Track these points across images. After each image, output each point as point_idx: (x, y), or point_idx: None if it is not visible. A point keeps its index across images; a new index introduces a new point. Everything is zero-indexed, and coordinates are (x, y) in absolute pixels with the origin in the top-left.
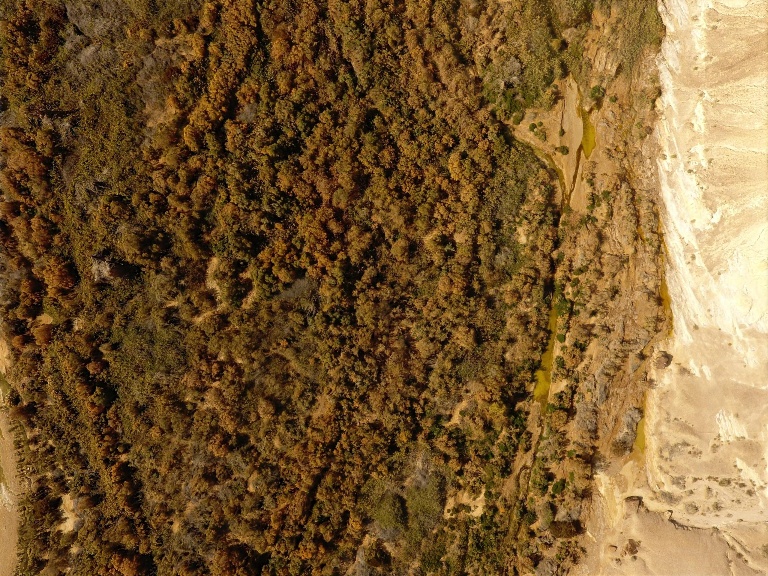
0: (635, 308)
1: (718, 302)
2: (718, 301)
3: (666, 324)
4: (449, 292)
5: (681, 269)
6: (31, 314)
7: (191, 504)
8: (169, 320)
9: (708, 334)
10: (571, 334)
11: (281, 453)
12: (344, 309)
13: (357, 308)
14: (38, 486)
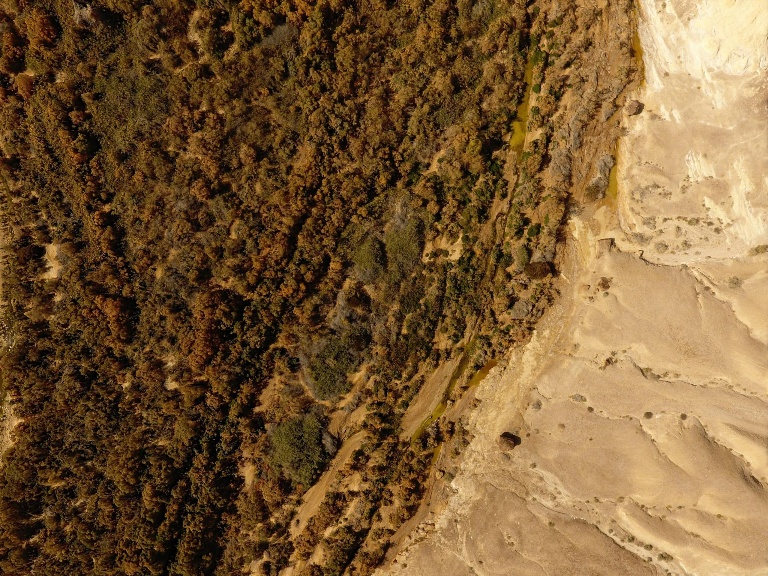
0: (608, 59)
1: (688, 48)
2: (688, 47)
3: (638, 74)
4: (427, 36)
5: (652, 20)
6: (13, 69)
7: (174, 251)
8: (151, 67)
9: (678, 79)
10: (546, 83)
11: (263, 201)
12: (324, 55)
13: (337, 55)
14: (21, 234)
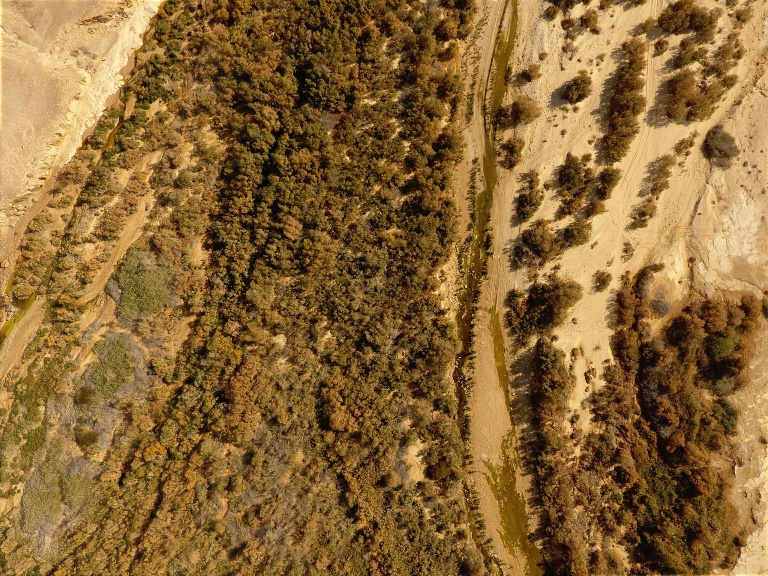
0: None
1: None
2: None
3: None
4: None
5: None
6: None
7: (285, 482)
8: None
9: None
10: None
11: (194, 540)
12: None
13: None
14: None
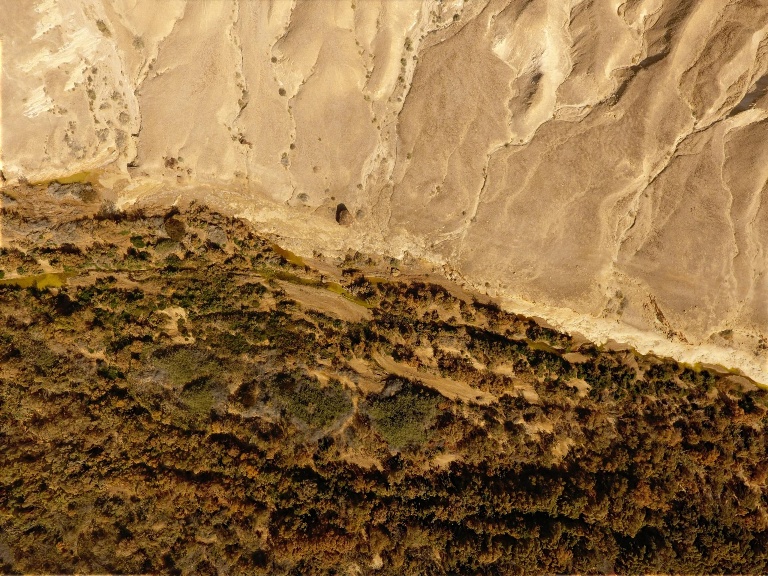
0: None
1: None
2: None
3: None
4: None
5: None
6: None
7: None
8: None
9: None
10: None
11: (173, 518)
12: (8, 496)
13: (6, 483)
14: None
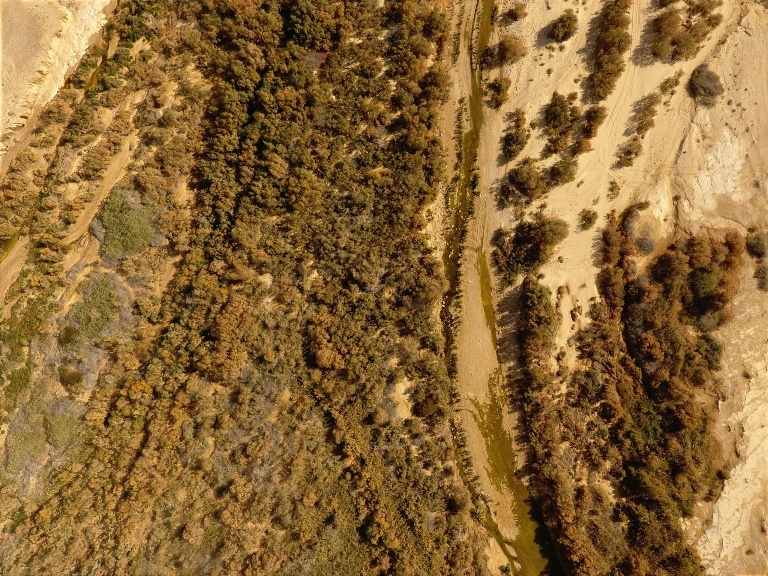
0: None
1: None
2: None
3: None
4: None
5: None
6: None
7: (272, 420)
8: None
9: None
10: None
11: (181, 479)
12: None
13: None
14: None
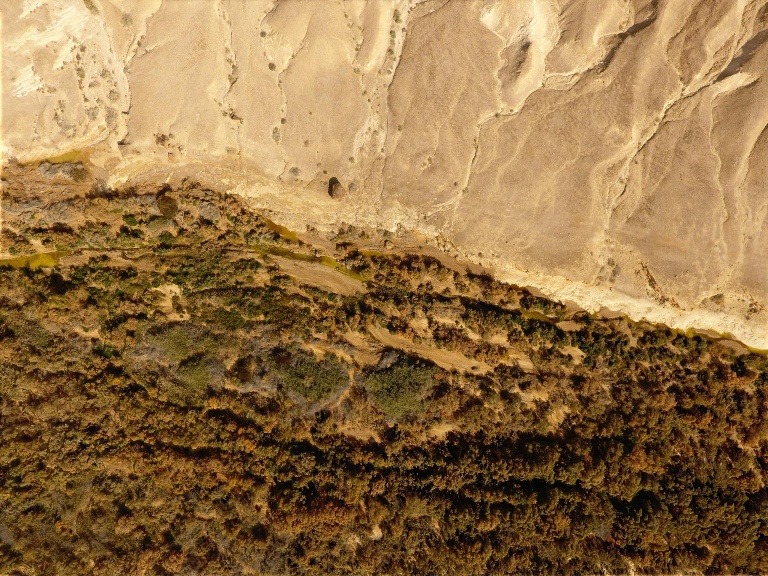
0: None
1: None
2: None
3: None
4: None
5: None
6: None
7: (244, 570)
8: None
9: None
10: None
11: (172, 494)
12: (5, 476)
13: (3, 463)
14: None
